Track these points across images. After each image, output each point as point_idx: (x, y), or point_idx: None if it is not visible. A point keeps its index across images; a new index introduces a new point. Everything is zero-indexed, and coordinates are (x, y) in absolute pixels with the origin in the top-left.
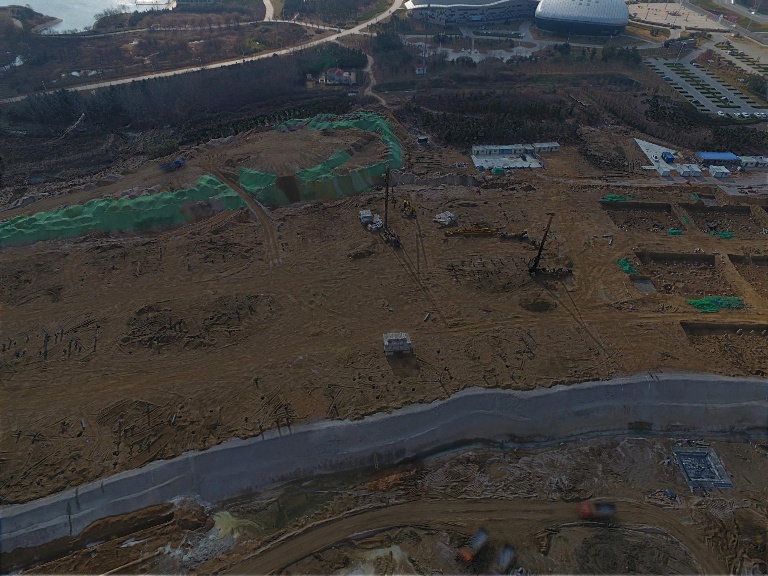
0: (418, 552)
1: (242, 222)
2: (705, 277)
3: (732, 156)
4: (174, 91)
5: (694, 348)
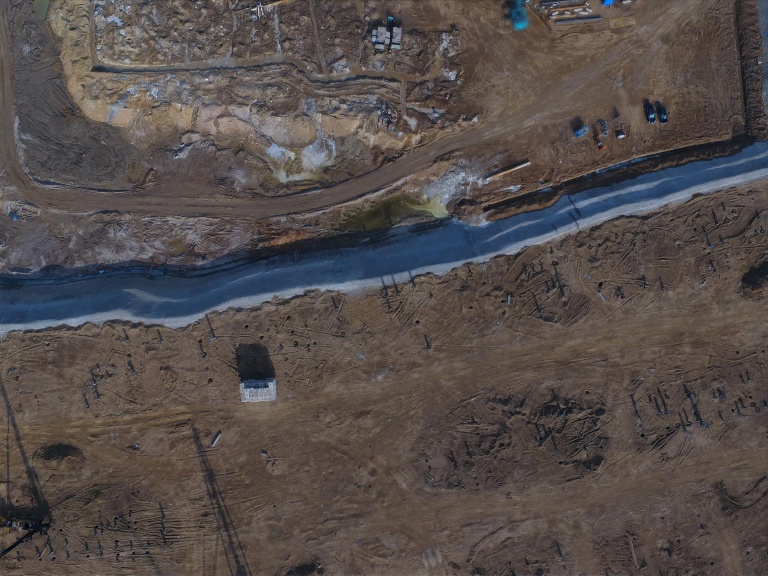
0: (264, 176)
1: None
2: None
3: None
4: None
5: None
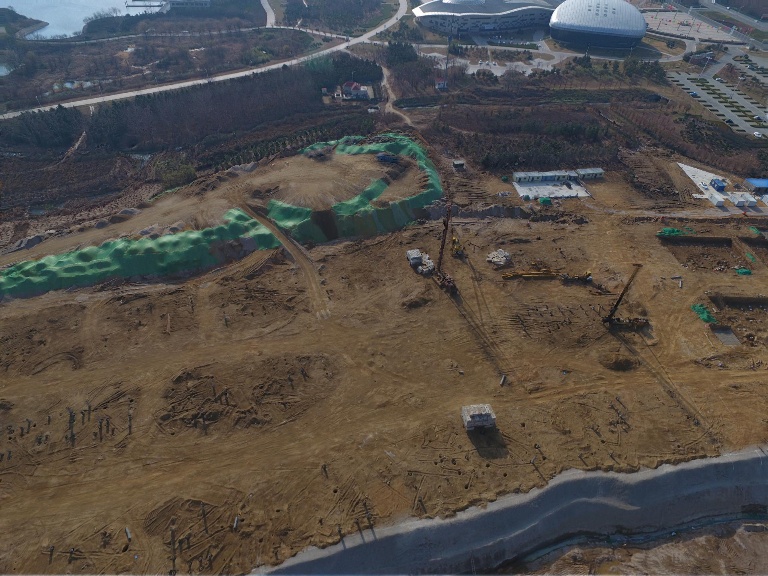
0: None
1: (278, 264)
2: None
3: None
4: (186, 110)
5: None
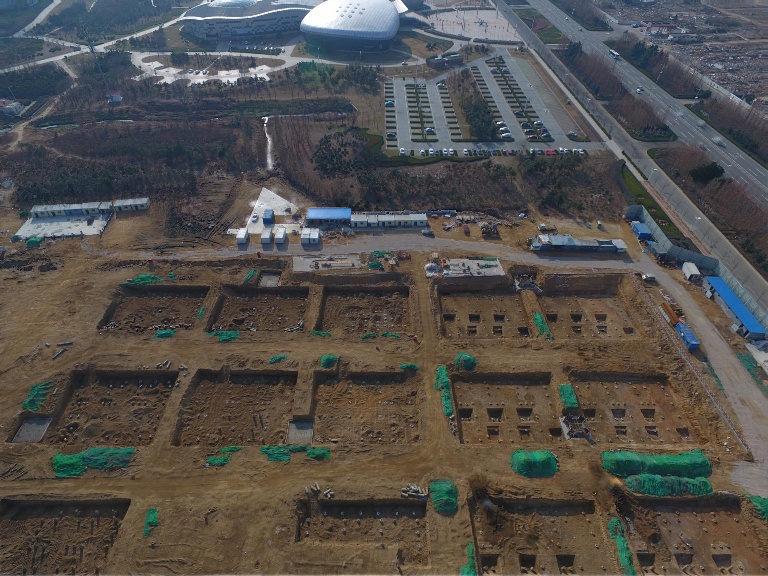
0: None
1: None
2: (139, 408)
3: (345, 213)
4: None
5: None
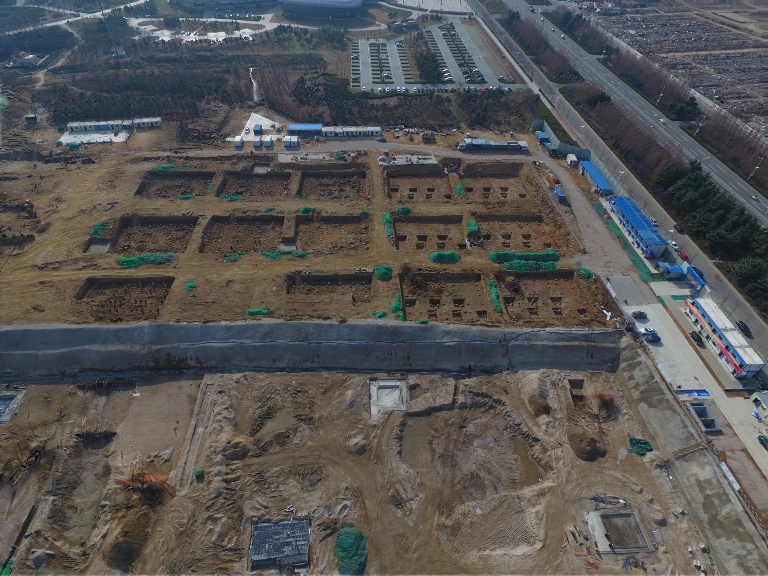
0: None
1: None
2: (172, 237)
3: (317, 127)
4: None
5: (72, 301)
